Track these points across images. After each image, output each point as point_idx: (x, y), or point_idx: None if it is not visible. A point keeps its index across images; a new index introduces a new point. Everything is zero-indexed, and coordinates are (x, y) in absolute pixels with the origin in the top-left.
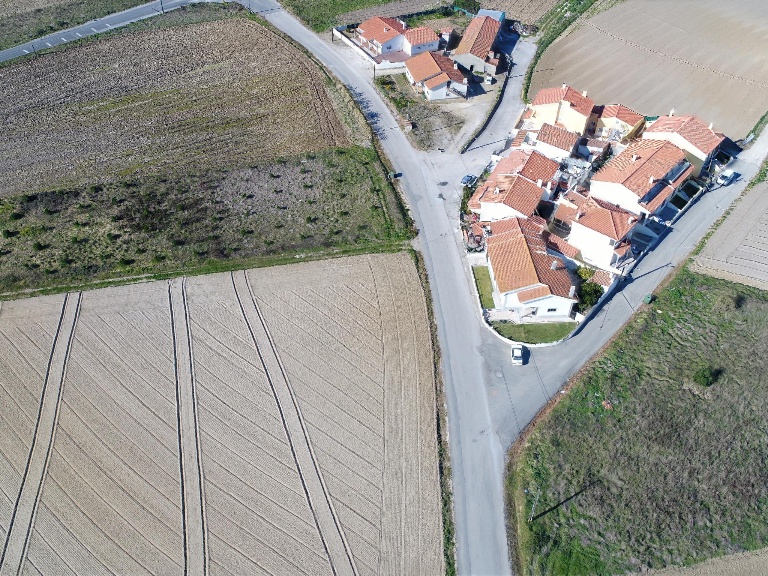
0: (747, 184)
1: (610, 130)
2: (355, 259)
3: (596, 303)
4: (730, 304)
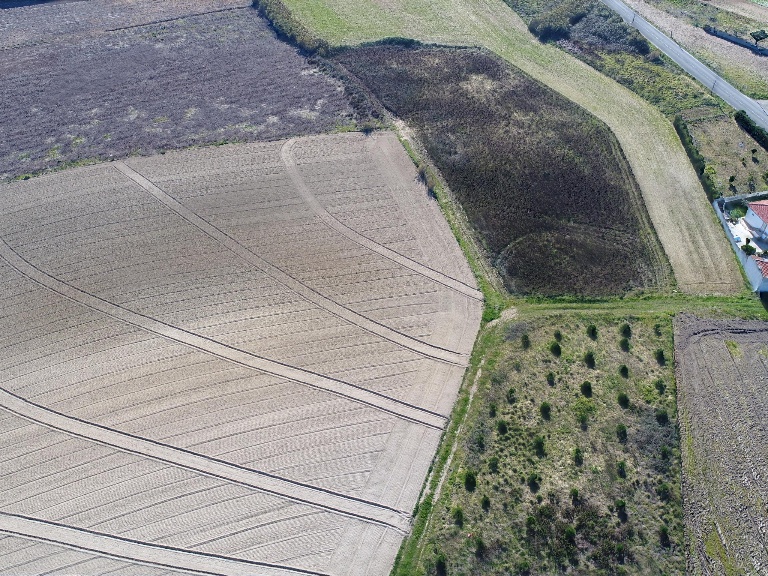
0: None
1: None
2: None
3: None
4: None
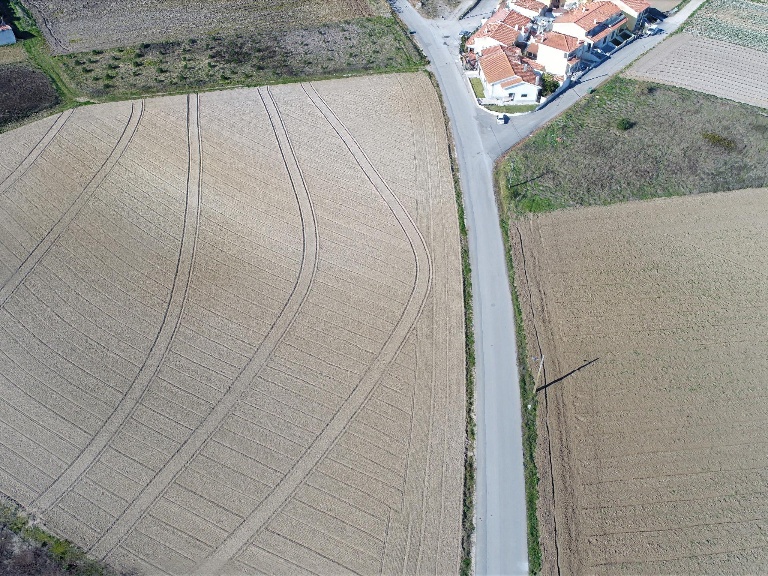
0: (668, 35)
1: (570, 3)
2: (387, 75)
3: (554, 92)
4: (644, 89)
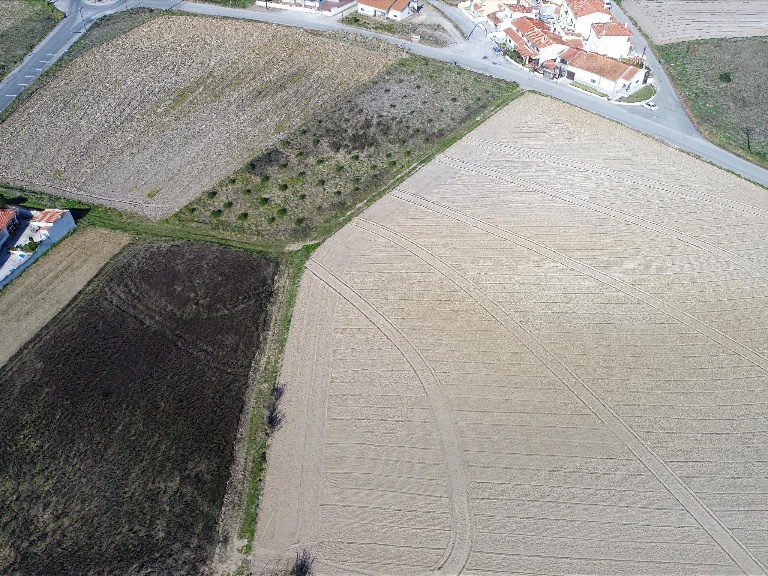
0: (617, 5)
1: (527, 0)
2: (510, 106)
3: None
4: None
